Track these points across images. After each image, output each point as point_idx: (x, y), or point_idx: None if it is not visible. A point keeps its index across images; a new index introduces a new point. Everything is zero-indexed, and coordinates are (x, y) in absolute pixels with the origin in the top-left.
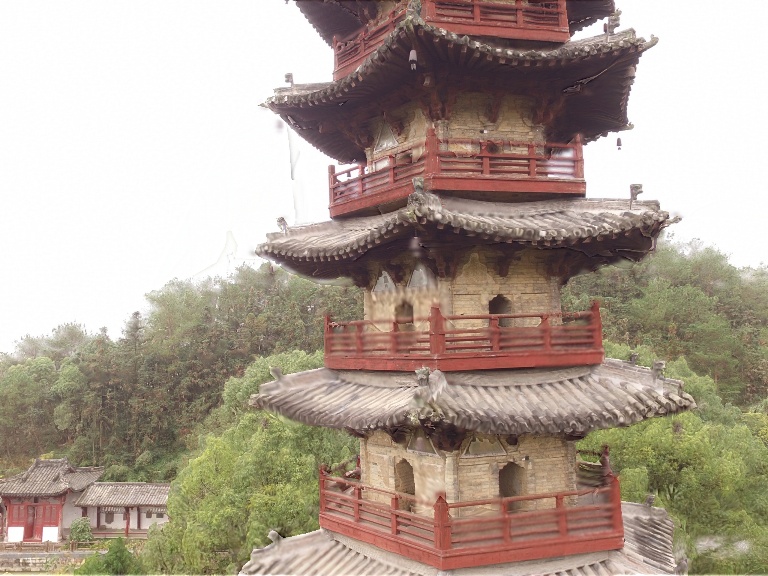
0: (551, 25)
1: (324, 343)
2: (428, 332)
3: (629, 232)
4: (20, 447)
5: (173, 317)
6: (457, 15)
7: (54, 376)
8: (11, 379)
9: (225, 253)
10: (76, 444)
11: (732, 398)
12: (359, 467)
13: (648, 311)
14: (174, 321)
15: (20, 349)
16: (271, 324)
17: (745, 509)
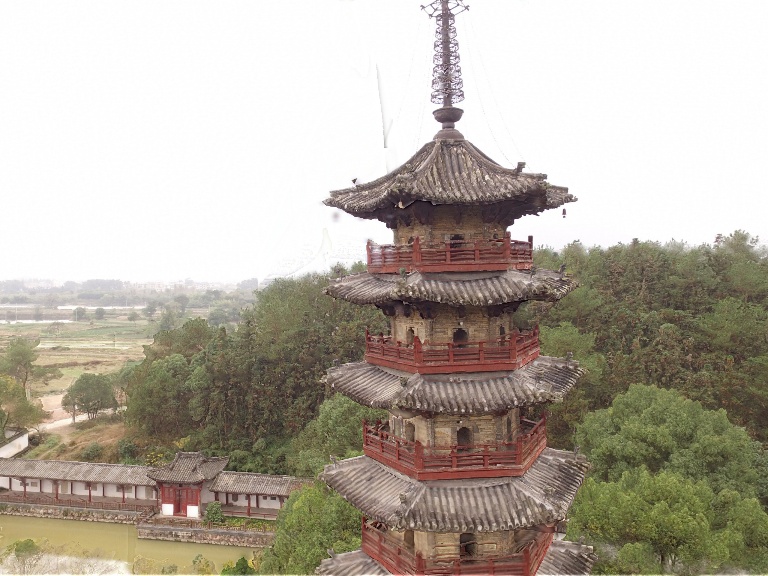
0: (504, 358)
1: None
2: (415, 567)
3: (538, 525)
4: (164, 426)
5: (278, 323)
6: (438, 359)
7: (187, 371)
8: (154, 374)
9: (321, 252)
10: (207, 431)
11: None
12: None
13: (715, 331)
14: (279, 326)
15: (159, 343)
16: (361, 331)
17: (740, 575)
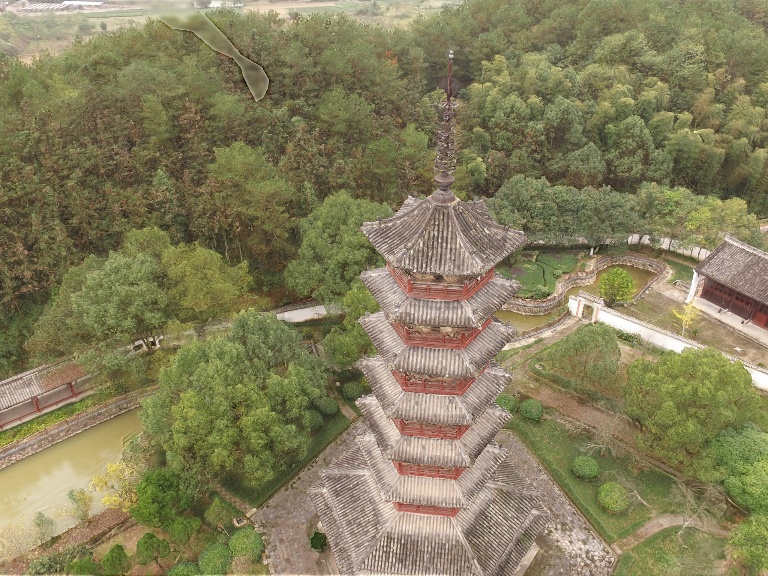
0: None
1: (401, 428)
2: None
3: None
4: None
5: None
6: None
7: None
8: None
9: None
10: None
11: None
12: None
13: (332, 120)
14: None
15: None
16: (6, 191)
17: None
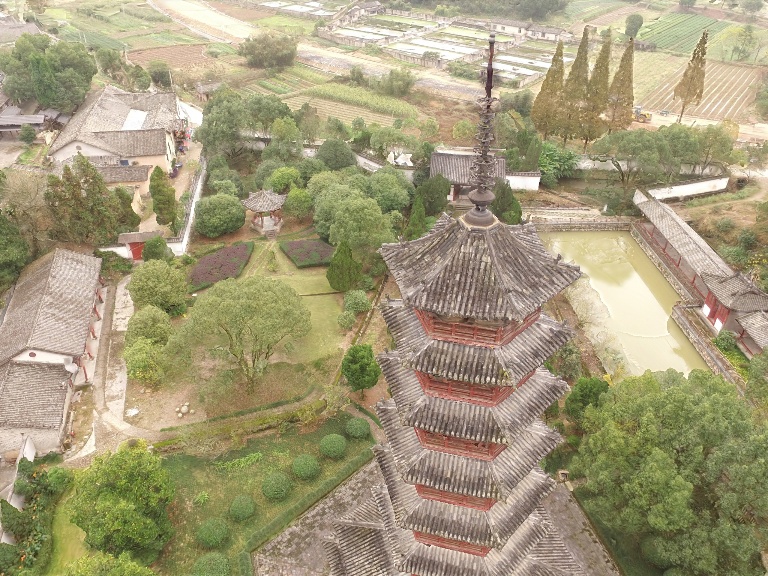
0: None
1: None
2: None
3: None
4: None
5: None
6: None
7: None
8: None
9: None
10: None
11: None
12: None
13: None
14: None
15: None
16: None
17: None
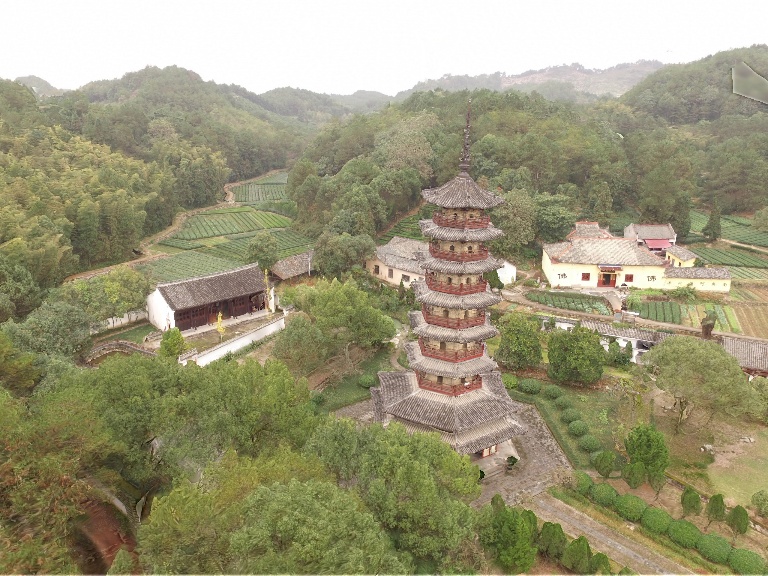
0: None
1: None
2: None
3: None
4: None
5: None
6: None
7: None
8: None
9: None
10: None
11: (6, 391)
12: (466, 352)
13: None
14: None
15: None
16: None
17: None
